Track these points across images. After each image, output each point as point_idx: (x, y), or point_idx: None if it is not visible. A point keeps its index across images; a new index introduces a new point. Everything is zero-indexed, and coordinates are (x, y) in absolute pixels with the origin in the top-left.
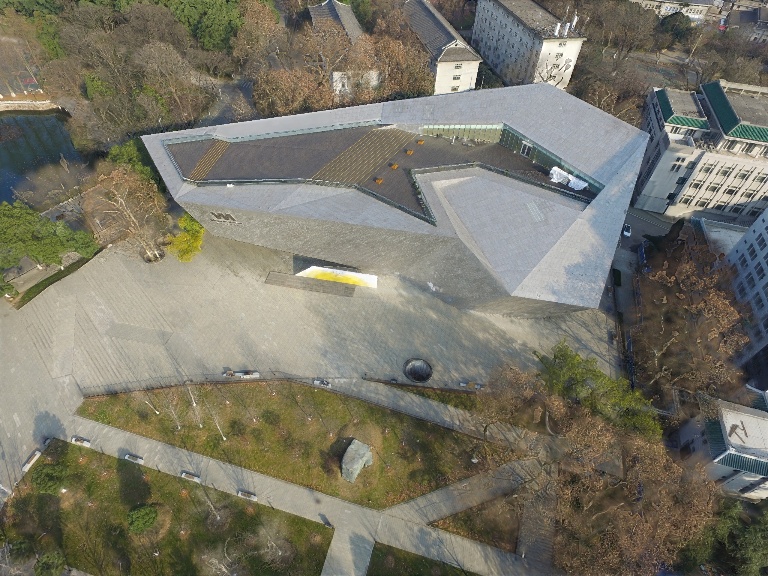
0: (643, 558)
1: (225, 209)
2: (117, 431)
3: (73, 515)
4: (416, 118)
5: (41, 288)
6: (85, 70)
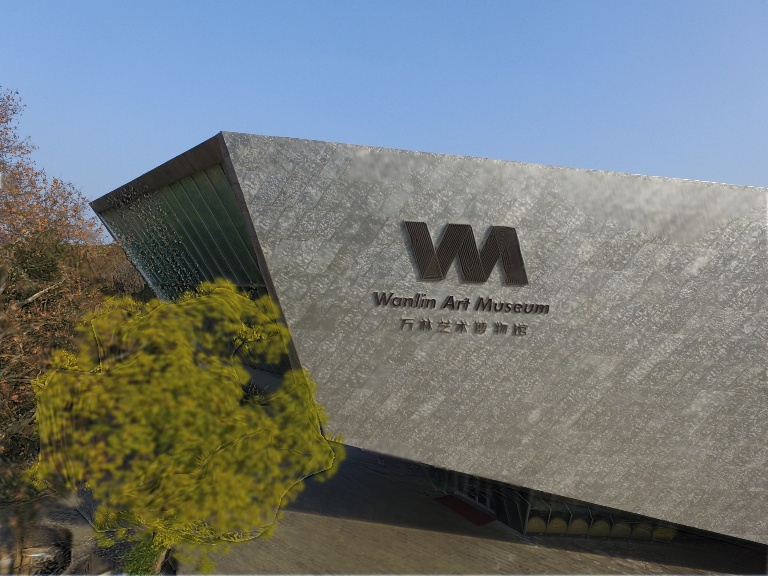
0: None
1: (502, 187)
2: None
3: None
4: None
5: None
6: None
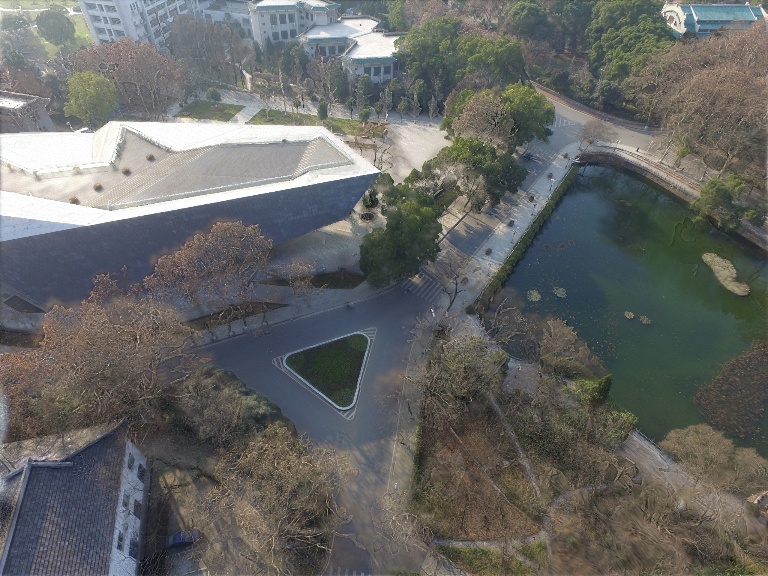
0: (123, 59)
1: None
2: (352, 141)
3: (357, 123)
4: (59, 205)
5: (447, 194)
6: (762, 573)
